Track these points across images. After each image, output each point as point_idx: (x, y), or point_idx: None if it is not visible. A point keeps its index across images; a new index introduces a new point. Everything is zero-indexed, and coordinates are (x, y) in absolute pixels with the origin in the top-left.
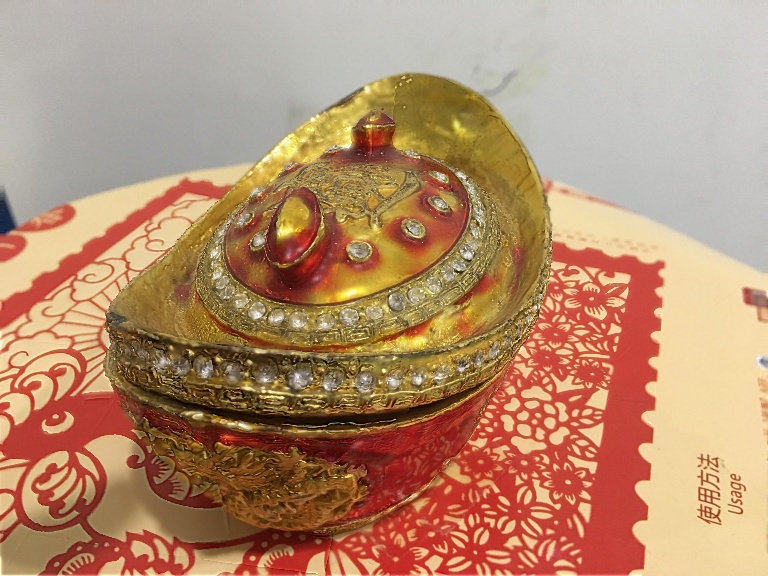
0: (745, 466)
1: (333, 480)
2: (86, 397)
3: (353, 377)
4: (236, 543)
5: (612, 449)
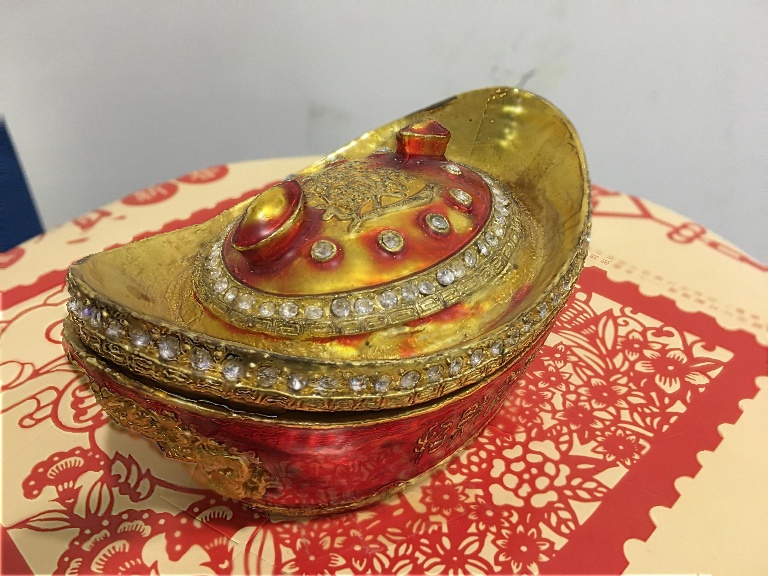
0: None
1: (223, 457)
2: None
3: (219, 362)
4: (191, 492)
5: (593, 532)
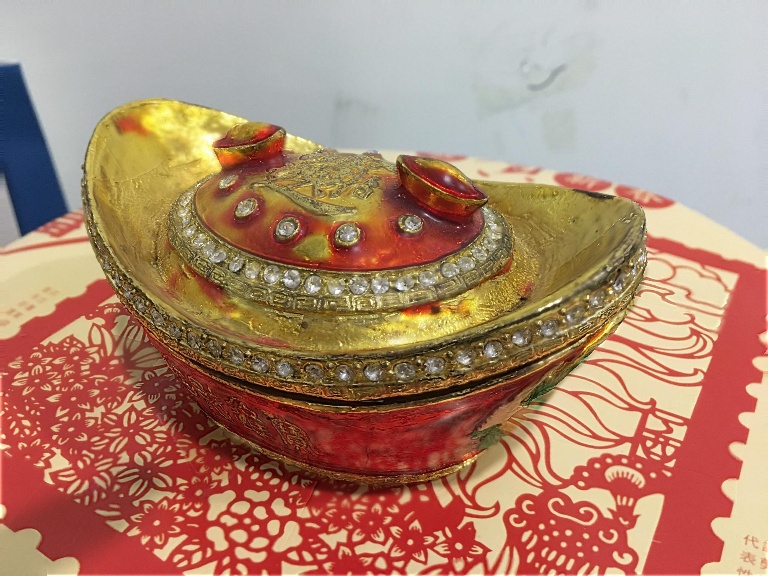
0: None
1: None
2: None
3: None
4: None
5: None
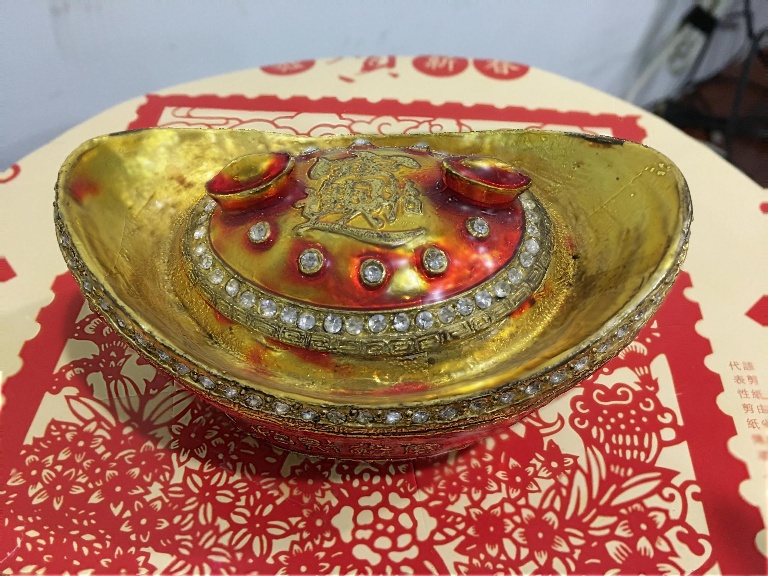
0: None
1: None
2: None
3: None
4: None
5: None
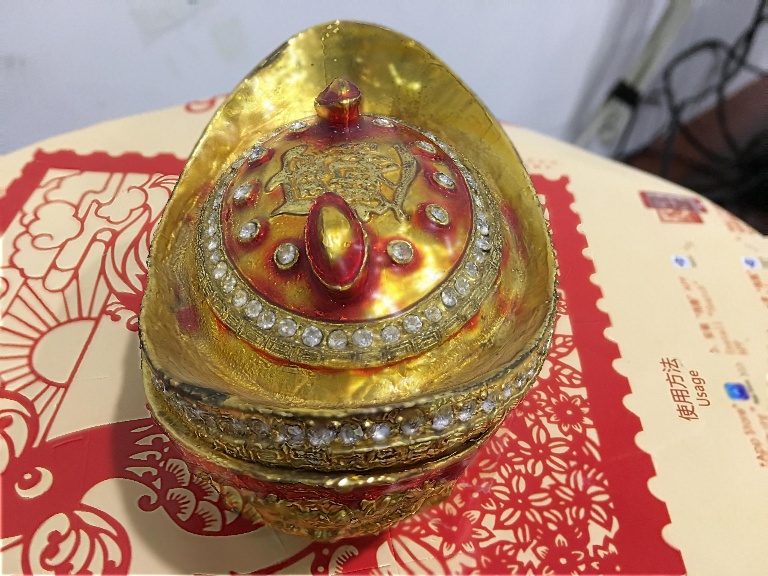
0: (698, 361)
1: None
2: (53, 444)
3: (483, 402)
4: (297, 559)
5: (593, 372)
